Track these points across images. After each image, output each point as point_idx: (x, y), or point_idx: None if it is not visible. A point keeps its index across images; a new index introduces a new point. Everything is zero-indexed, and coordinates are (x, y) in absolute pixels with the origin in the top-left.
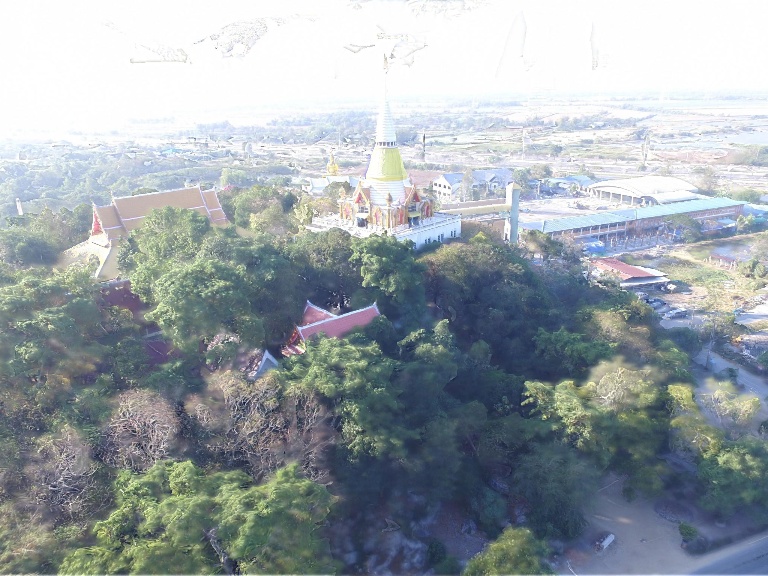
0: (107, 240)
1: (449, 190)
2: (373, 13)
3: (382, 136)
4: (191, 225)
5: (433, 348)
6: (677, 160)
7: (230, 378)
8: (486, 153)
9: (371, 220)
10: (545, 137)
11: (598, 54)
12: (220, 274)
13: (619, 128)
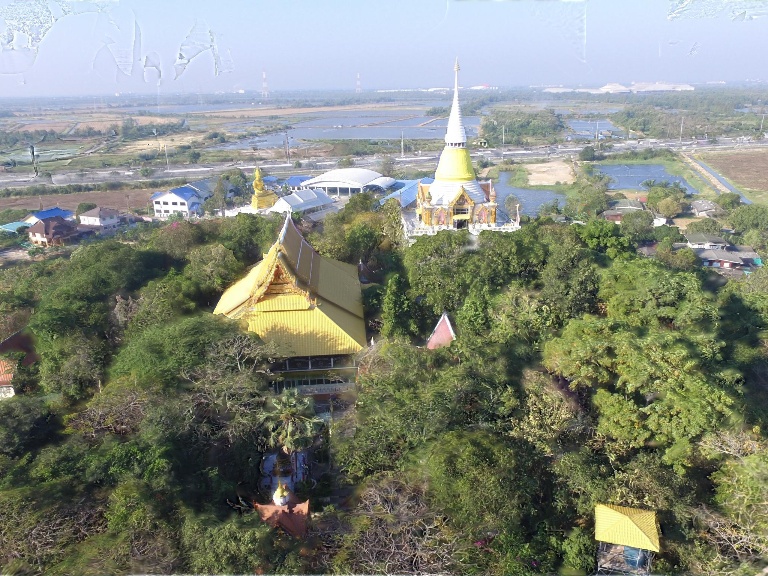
0: (305, 300)
1: (183, 206)
2: (766, 25)
3: (461, 137)
4: (513, 241)
5: None
6: (299, 156)
7: None
8: (104, 168)
9: (472, 220)
10: (127, 147)
11: (220, 60)
12: None
13: (180, 133)
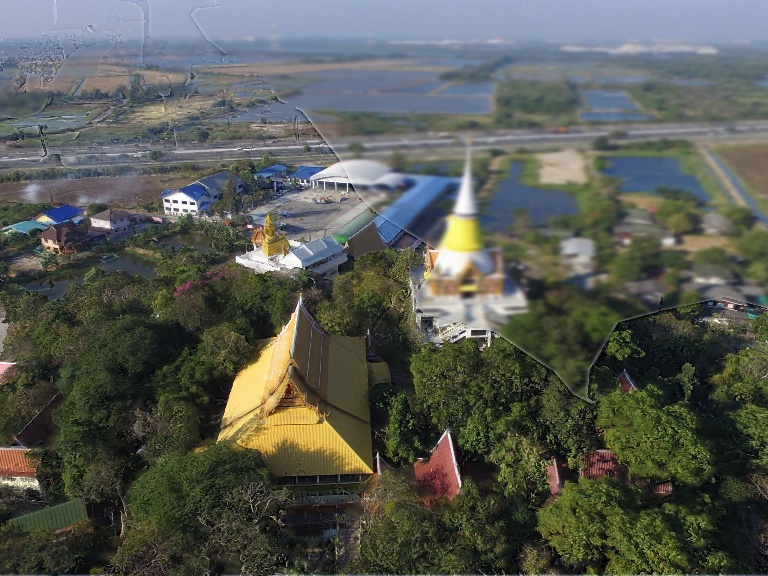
0: (314, 414)
1: (193, 206)
2: None
3: None
4: (517, 362)
5: (728, 390)
6: (309, 135)
7: None
8: (112, 144)
9: None
10: (135, 114)
11: None
12: (657, 401)
13: None
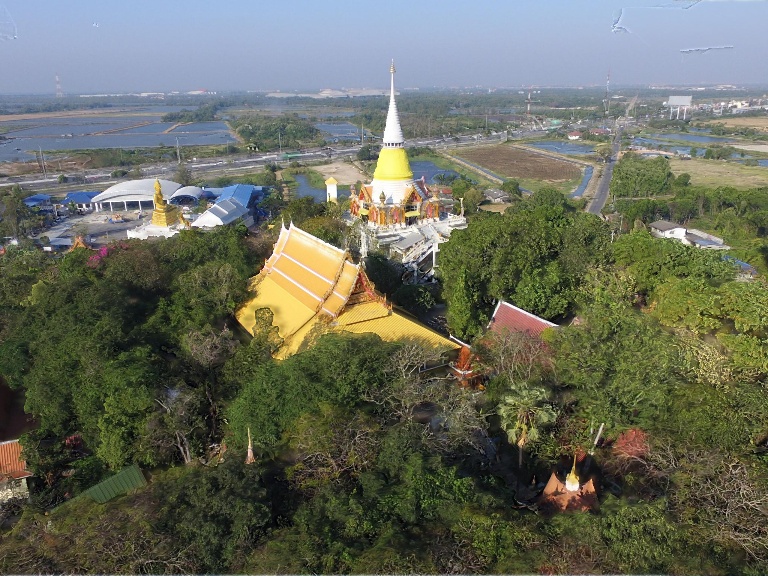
0: (382, 307)
1: None
2: None
3: (401, 137)
4: None
5: None
6: (50, 170)
7: (748, 280)
8: None
9: None
10: None
11: None
12: None
13: None
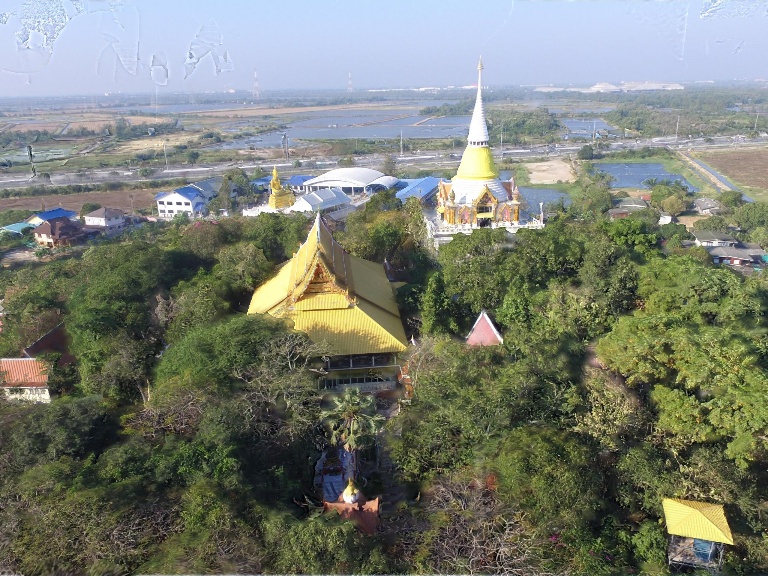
0: (344, 299)
1: (188, 206)
2: None
3: (484, 135)
4: (551, 239)
5: None
6: (297, 156)
7: None
8: (101, 168)
9: (495, 218)
10: (122, 147)
11: (218, 59)
12: None
13: (174, 133)
